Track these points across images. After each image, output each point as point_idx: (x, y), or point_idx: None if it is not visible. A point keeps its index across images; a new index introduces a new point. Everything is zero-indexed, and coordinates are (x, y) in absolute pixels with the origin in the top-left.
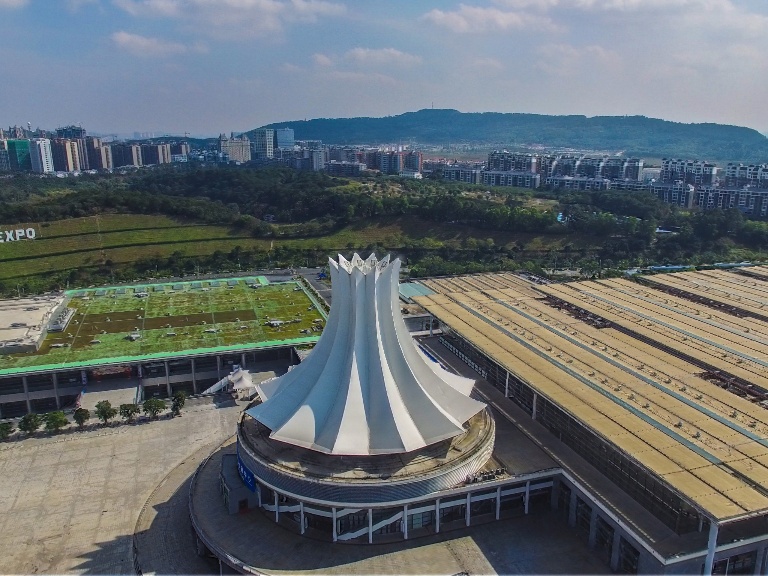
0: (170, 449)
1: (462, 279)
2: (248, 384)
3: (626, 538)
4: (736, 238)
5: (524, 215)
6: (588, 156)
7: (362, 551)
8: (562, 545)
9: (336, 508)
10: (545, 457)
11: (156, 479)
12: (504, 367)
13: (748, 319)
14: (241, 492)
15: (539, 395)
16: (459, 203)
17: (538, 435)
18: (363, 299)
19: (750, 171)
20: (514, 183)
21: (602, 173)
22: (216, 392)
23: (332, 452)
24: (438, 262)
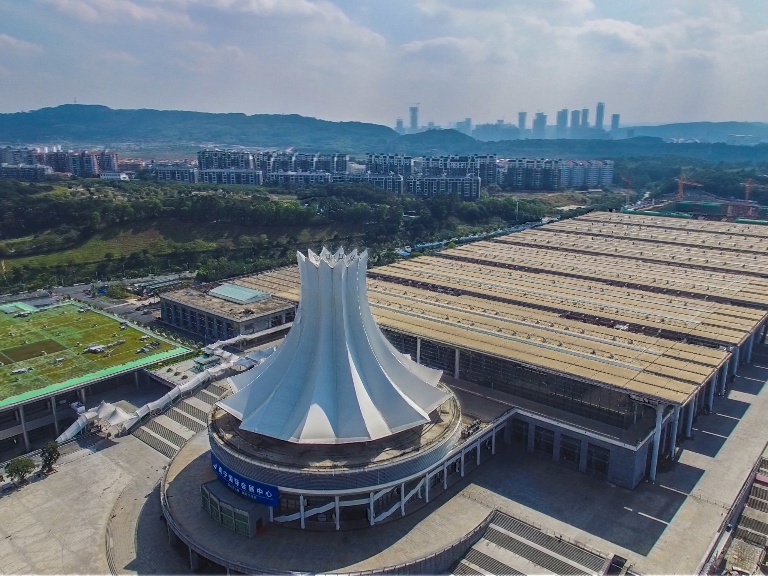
0: (80, 508)
1: (268, 275)
2: (126, 416)
3: (595, 443)
4: (458, 217)
5: (289, 209)
6: (301, 152)
7: (403, 524)
8: (538, 467)
9: (375, 492)
10: (495, 404)
11: (96, 542)
12: (430, 338)
13: (544, 274)
14: (257, 511)
15: (465, 356)
16: (220, 202)
17: (473, 389)
18: (345, 291)
19: (441, 162)
20: (237, 180)
21: (316, 168)
22: (76, 436)
23: (371, 438)
24: (225, 263)
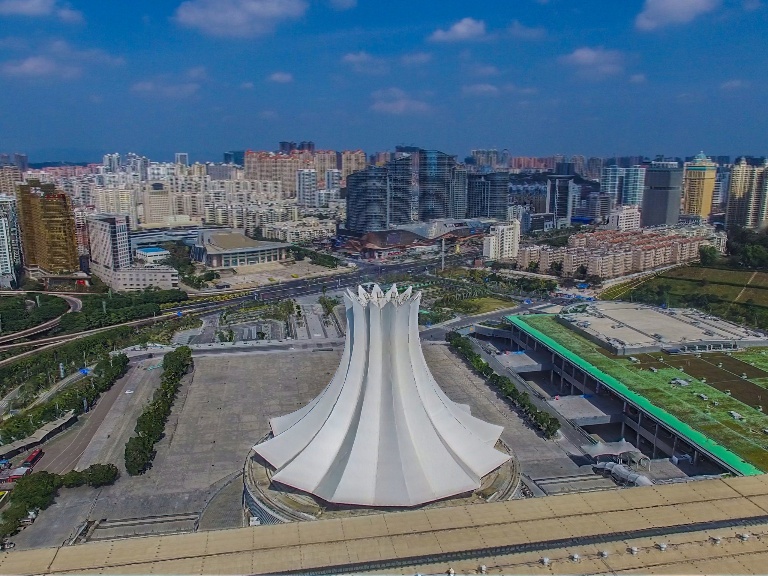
0: None
1: None
2: (593, 451)
3: None
4: None
5: None
6: None
7: None
8: None
9: None
10: None
11: None
12: None
13: None
14: None
15: None
16: None
17: None
18: None
19: None
20: None
21: None
22: None
23: None
24: None
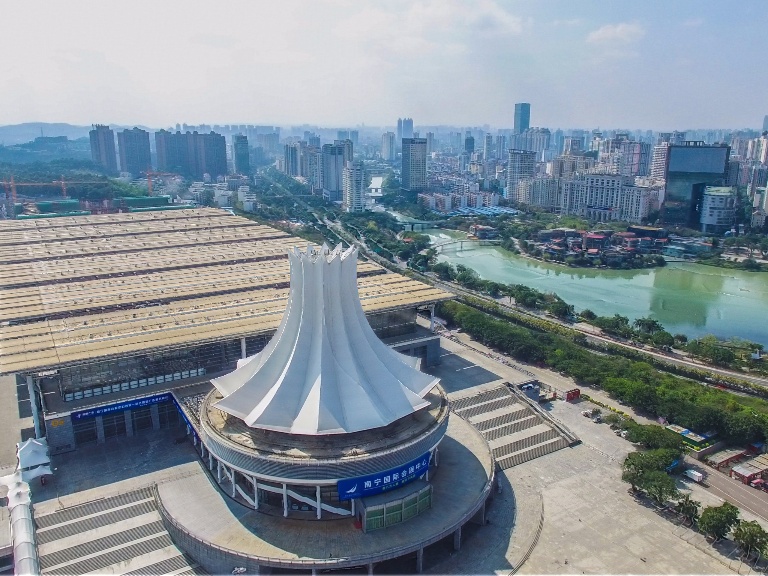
0: None
1: None
2: None
3: None
4: None
5: None
6: None
7: None
8: None
9: None
10: None
11: None
12: None
13: (168, 271)
14: None
15: None
16: None
17: None
18: None
19: None
20: None
21: None
22: None
23: None
24: None
